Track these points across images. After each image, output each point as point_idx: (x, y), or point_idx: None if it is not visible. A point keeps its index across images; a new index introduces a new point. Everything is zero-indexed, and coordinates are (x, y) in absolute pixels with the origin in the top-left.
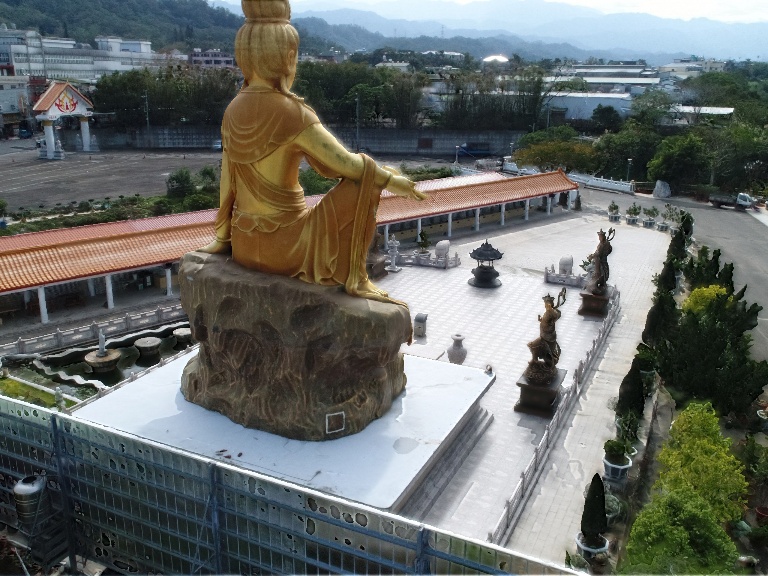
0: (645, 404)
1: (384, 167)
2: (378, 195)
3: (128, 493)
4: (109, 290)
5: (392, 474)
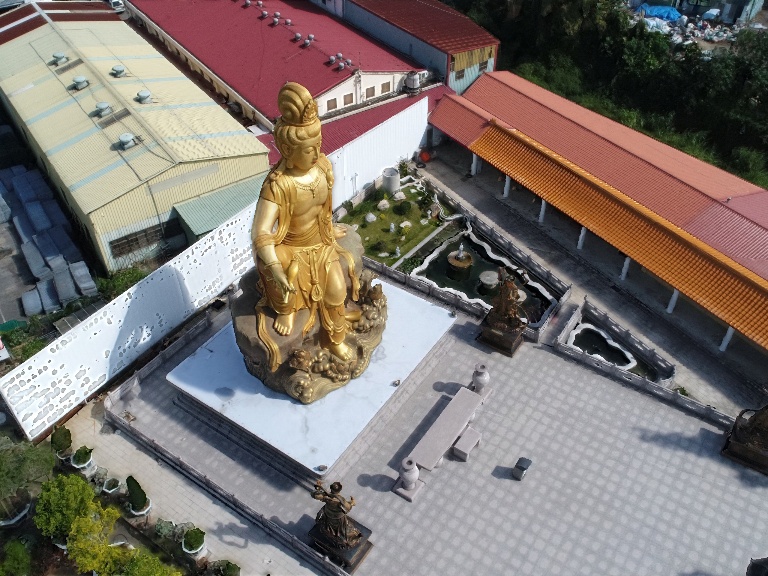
0: None
1: (292, 261)
2: (266, 269)
3: (192, 275)
4: (581, 234)
5: (196, 383)
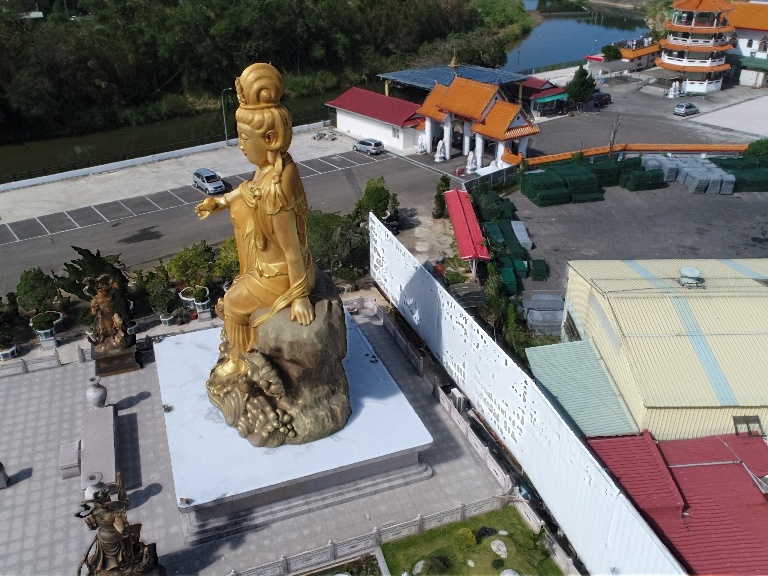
0: (72, 340)
1: None
2: None
3: None
4: None
5: None
